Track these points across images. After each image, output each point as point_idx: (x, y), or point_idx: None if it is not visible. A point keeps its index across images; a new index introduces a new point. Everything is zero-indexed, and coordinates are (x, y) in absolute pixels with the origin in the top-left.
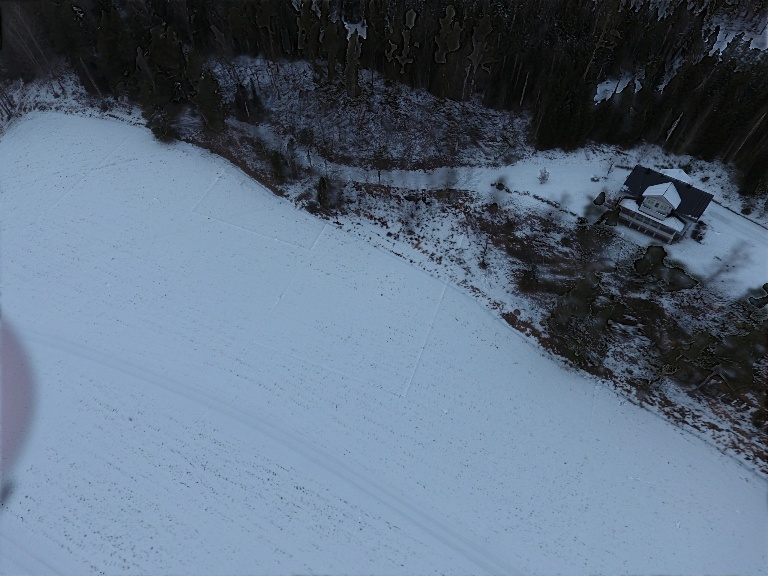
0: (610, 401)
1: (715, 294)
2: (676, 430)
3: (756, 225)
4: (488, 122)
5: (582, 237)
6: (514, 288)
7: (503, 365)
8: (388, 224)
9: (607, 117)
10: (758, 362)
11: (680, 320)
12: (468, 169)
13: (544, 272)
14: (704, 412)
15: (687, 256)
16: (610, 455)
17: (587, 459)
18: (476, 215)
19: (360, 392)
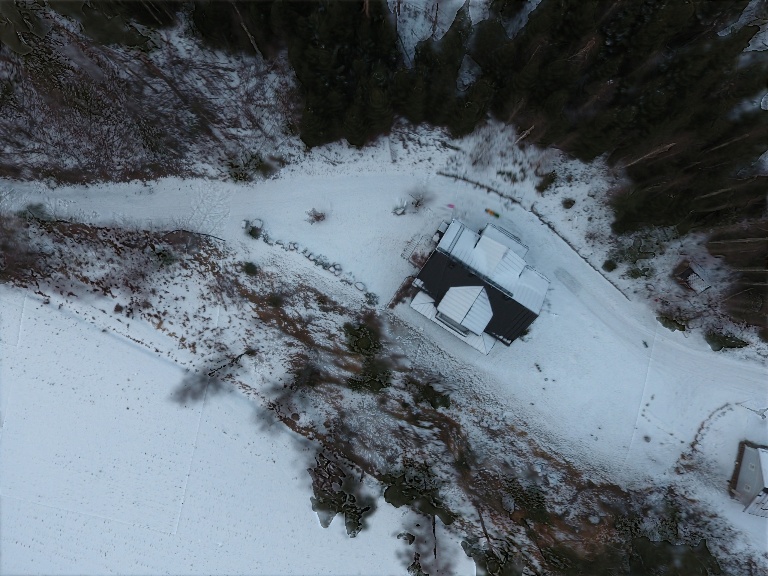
0: (392, 512)
1: (520, 418)
2: (452, 539)
3: (615, 291)
4: (219, 85)
5: (371, 322)
6: (293, 379)
7: (281, 483)
8: (112, 292)
9: (413, 102)
10: (546, 493)
11: (475, 441)
12: (207, 184)
13: (327, 362)
14: (484, 523)
15: (498, 365)
16: (383, 568)
17: (360, 575)
18: (229, 277)
19: (127, 536)
